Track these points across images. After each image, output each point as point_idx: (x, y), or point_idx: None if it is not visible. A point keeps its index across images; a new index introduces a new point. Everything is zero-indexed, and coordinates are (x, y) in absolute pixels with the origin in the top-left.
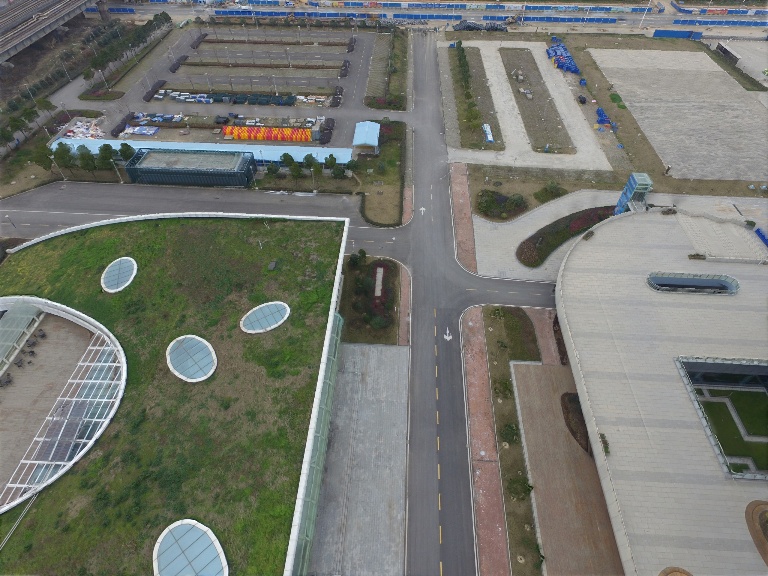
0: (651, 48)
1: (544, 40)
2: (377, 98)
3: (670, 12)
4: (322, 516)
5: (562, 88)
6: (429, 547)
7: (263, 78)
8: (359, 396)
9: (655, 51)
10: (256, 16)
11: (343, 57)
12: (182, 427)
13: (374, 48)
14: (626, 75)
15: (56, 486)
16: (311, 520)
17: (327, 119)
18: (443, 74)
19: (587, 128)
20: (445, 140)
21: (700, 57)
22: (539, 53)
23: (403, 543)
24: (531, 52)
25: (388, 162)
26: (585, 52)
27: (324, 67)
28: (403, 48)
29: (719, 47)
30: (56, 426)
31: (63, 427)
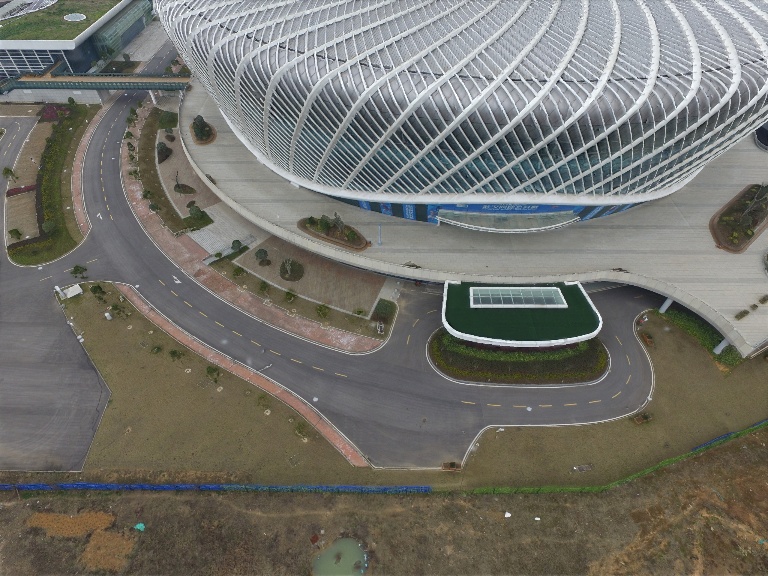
0: None
1: None
2: None
3: None
4: (131, 46)
5: None
6: (166, 50)
7: None
8: (156, 30)
9: None
10: None
11: None
12: (77, 5)
13: None
14: None
15: (34, 13)
16: (120, 29)
17: None
18: None
19: None
20: None
21: None
22: None
23: (157, 50)
24: None
25: None
26: None
27: None
28: None
29: None
30: (33, 4)
31: (36, 4)
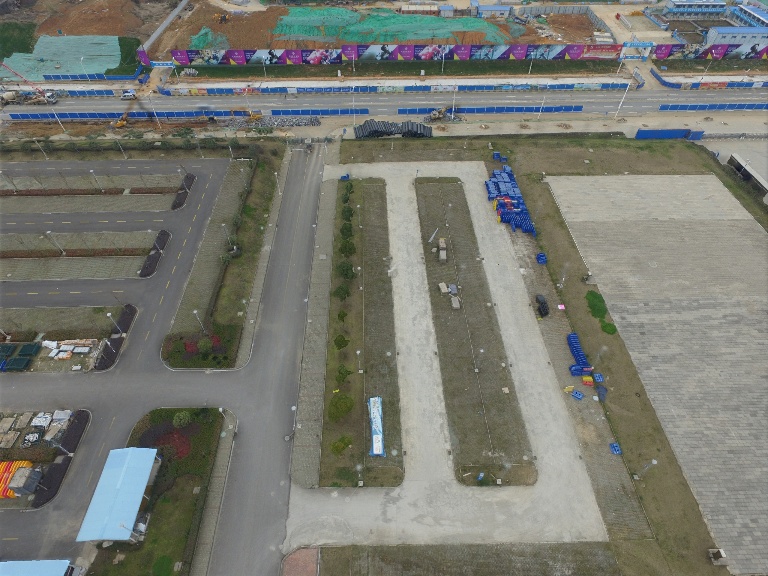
0: (638, 170)
1: (482, 157)
2: (186, 340)
3: (651, 86)
4: None
5: (509, 274)
6: None
7: (6, 287)
8: None
9: (644, 177)
10: (73, 119)
11: (163, 221)
12: None
13: (219, 195)
14: (608, 239)
15: None
16: None
17: (74, 415)
18: (319, 253)
19: (553, 391)
20: (290, 463)
21: (711, 187)
22: (474, 187)
23: None
24: (462, 186)
25: (156, 567)
26: (542, 185)
27: (119, 253)
28: (268, 188)
29: (733, 162)
30: None
31: None
